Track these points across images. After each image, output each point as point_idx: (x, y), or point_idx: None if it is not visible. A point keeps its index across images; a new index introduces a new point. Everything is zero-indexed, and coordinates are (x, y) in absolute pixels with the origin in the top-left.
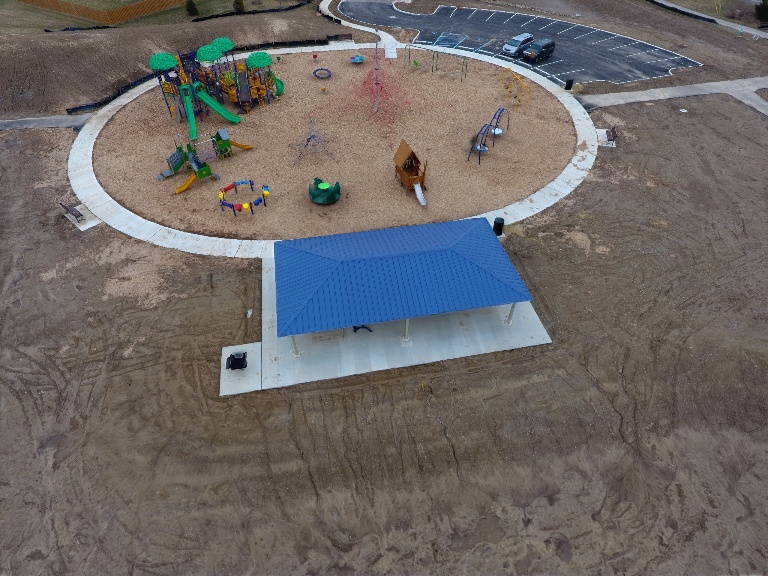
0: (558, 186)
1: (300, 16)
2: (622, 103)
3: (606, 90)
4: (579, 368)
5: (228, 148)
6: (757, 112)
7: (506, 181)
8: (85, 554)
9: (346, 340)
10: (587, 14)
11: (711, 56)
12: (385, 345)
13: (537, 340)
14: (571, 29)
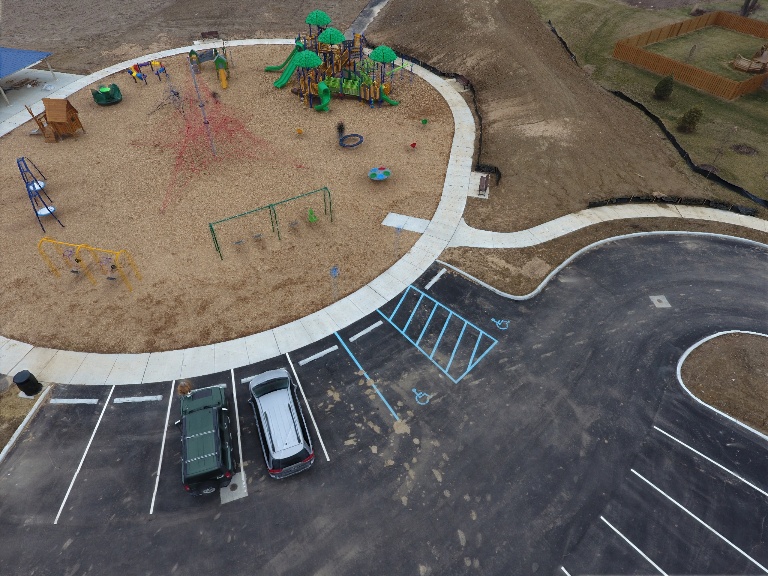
0: None
1: (631, 168)
2: None
3: None
4: None
5: (238, 81)
6: None
7: None
8: (9, 43)
9: None
10: None
11: None
12: None
13: None
14: None
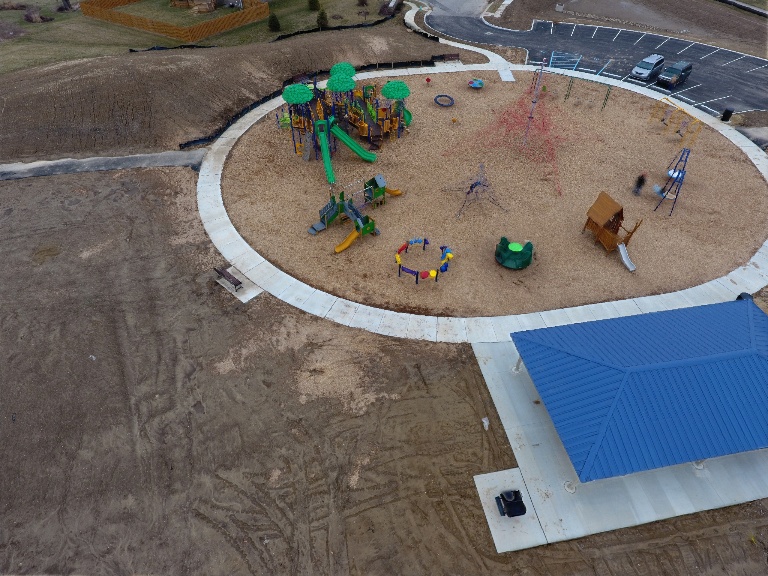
0: None
1: (392, 33)
2: None
3: None
4: None
5: None
6: None
7: (713, 238)
8: None
9: None
10: (694, 30)
11: None
12: (677, 475)
13: None
14: (690, 48)
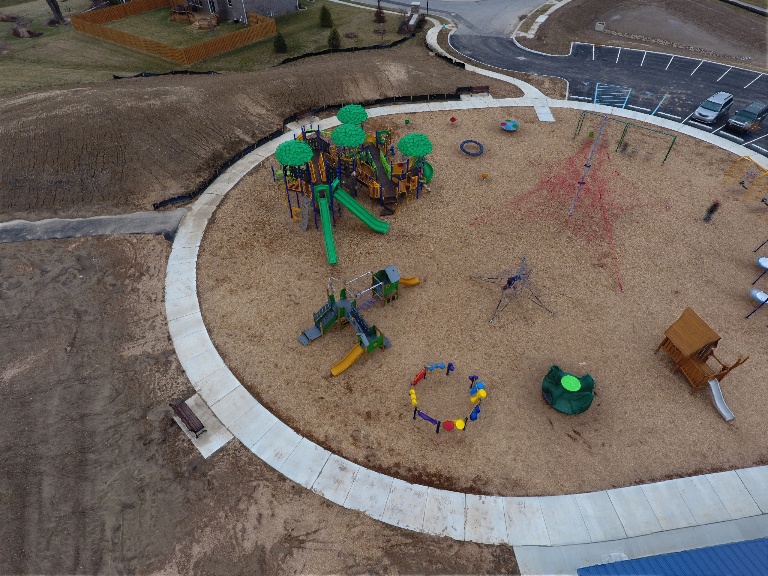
0: None
1: (412, 57)
2: None
3: None
4: None
5: None
6: None
7: None
8: None
9: None
10: (757, 56)
11: None
12: None
13: None
14: (758, 80)
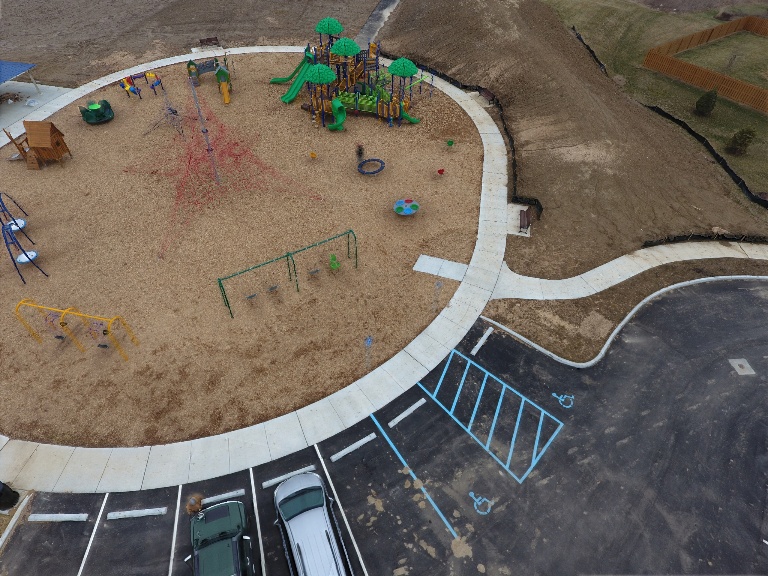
0: None
1: (685, 198)
2: None
3: None
4: None
5: (242, 95)
6: None
7: None
8: None
9: None
10: None
11: None
12: None
13: None
14: None
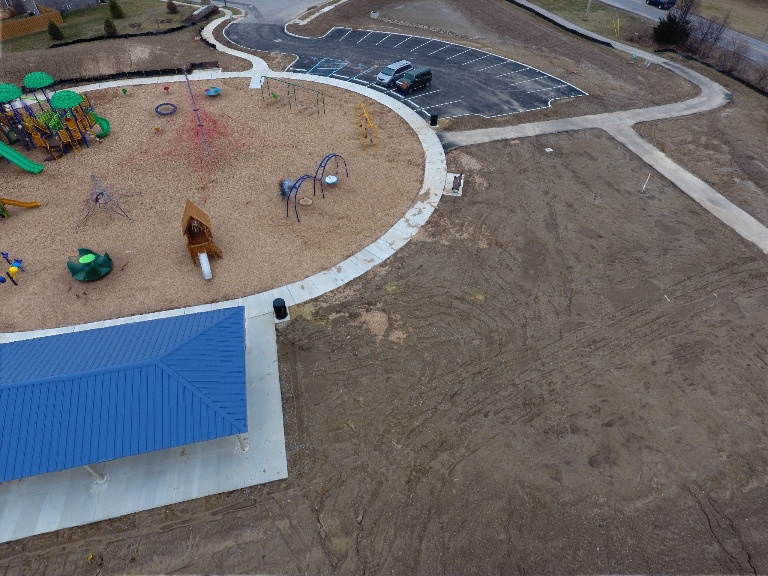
0: (378, 249)
1: (174, 40)
2: (486, 141)
3: (474, 125)
4: (308, 517)
5: (11, 205)
6: (627, 150)
7: (320, 243)
8: None
9: (21, 485)
10: (489, 36)
11: (599, 84)
12: (69, 491)
13: (269, 475)
14: (463, 54)
